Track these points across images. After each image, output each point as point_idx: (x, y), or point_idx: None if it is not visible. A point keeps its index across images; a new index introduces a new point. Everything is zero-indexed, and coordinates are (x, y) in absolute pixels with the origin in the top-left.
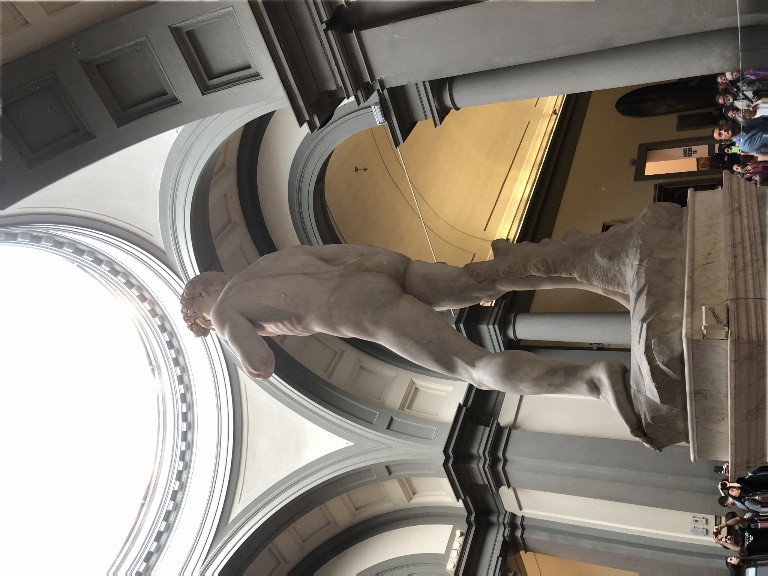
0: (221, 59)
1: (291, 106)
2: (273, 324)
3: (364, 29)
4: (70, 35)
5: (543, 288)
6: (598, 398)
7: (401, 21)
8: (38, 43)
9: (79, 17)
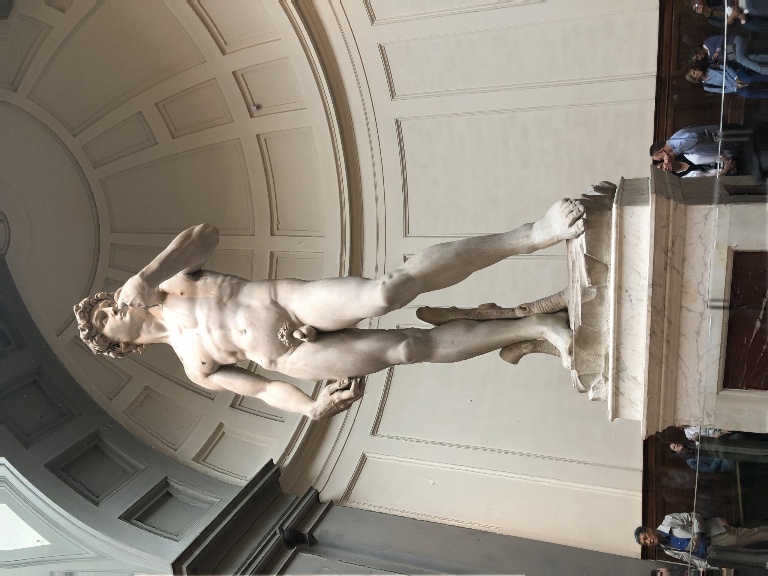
0: (162, 521)
1: (188, 546)
2: (215, 276)
3: (304, 553)
4: (117, 422)
5: (471, 342)
6: (530, 228)
7: (340, 561)
8: (100, 404)
9: (131, 430)
